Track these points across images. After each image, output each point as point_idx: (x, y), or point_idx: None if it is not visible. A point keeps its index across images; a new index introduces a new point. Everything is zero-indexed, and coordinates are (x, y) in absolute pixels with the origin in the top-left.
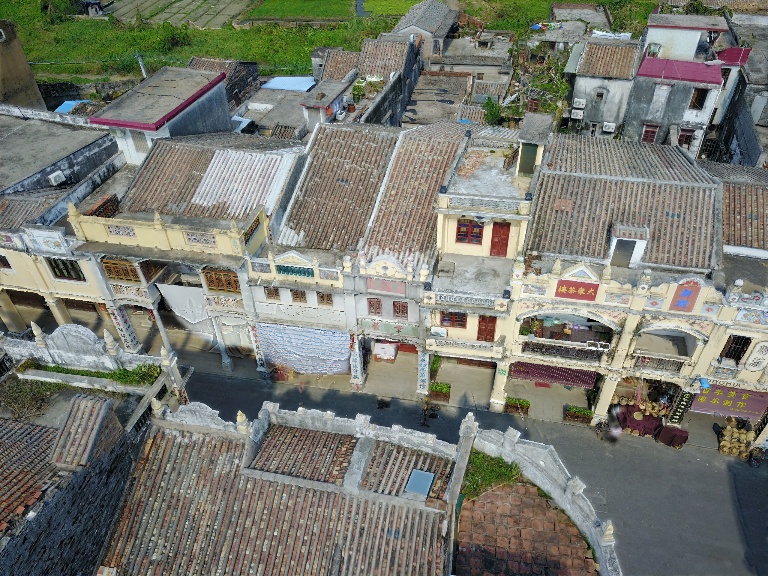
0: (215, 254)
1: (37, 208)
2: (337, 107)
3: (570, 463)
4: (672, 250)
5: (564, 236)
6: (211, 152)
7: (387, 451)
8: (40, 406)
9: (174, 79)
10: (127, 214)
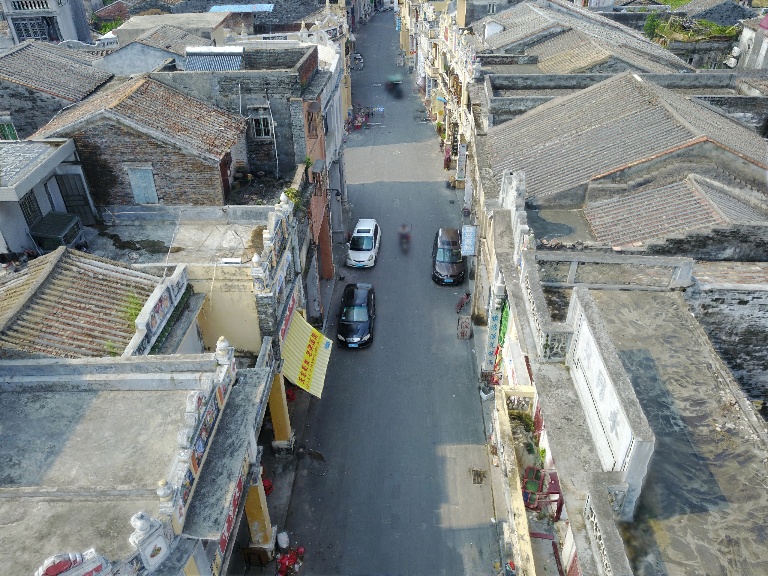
0: None
1: None
2: (592, 3)
3: None
4: None
5: None
6: None
7: None
8: None
9: None
10: None
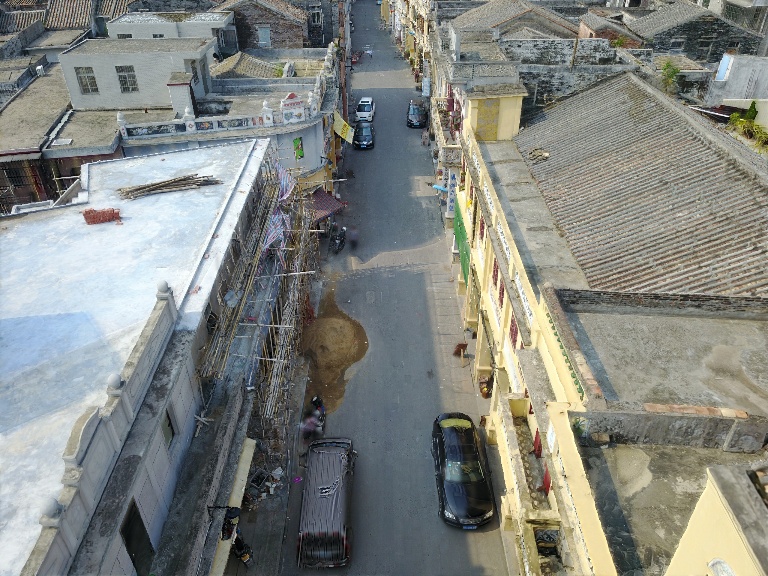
0: None
1: None
2: None
3: (394, 72)
4: None
5: None
6: None
7: None
8: None
9: None
10: None
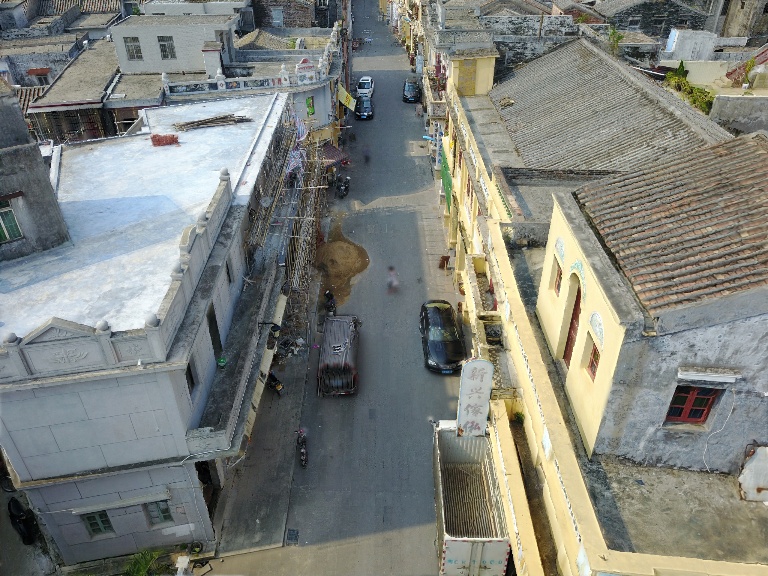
0: None
1: None
2: None
3: None
4: None
5: None
6: None
7: None
8: None
9: None
10: None
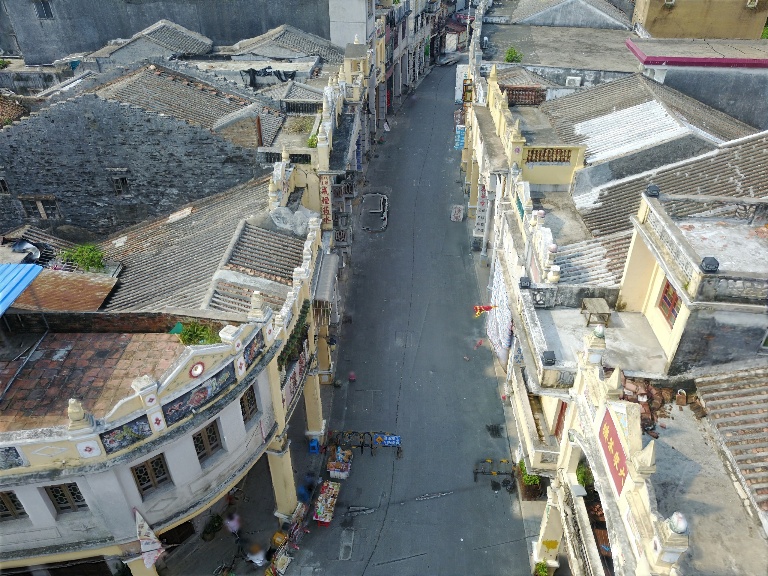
0: (506, 155)
1: (521, 84)
2: None
3: None
4: None
5: (766, 421)
6: (649, 99)
7: (277, 306)
8: (295, 131)
9: (763, 50)
10: (537, 110)
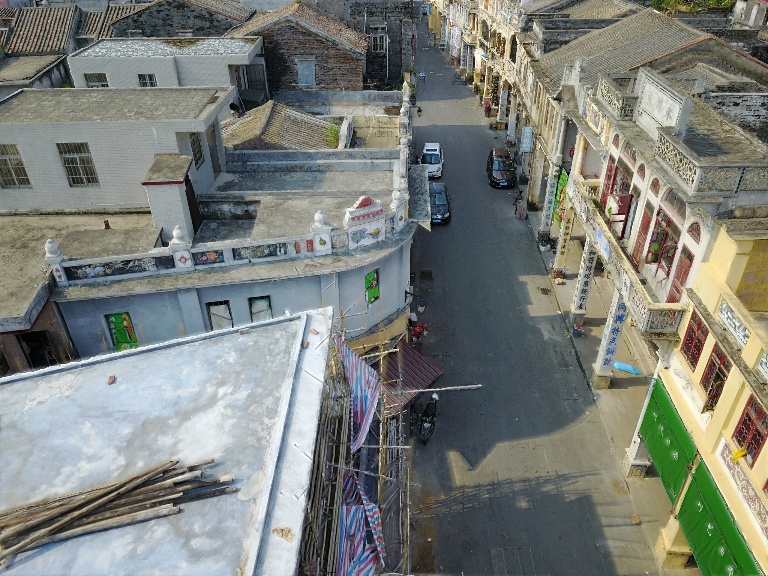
0: None
1: None
2: None
3: (456, 102)
4: (531, 5)
5: None
6: None
7: None
8: None
9: None
10: None
